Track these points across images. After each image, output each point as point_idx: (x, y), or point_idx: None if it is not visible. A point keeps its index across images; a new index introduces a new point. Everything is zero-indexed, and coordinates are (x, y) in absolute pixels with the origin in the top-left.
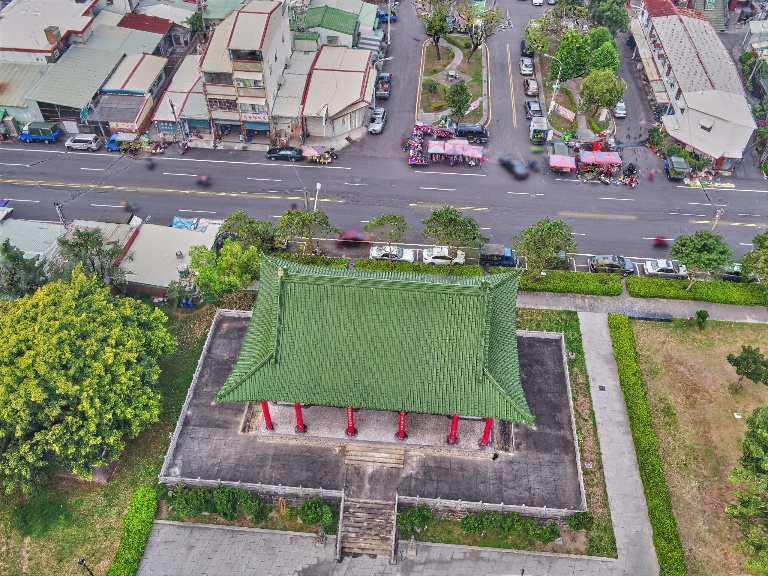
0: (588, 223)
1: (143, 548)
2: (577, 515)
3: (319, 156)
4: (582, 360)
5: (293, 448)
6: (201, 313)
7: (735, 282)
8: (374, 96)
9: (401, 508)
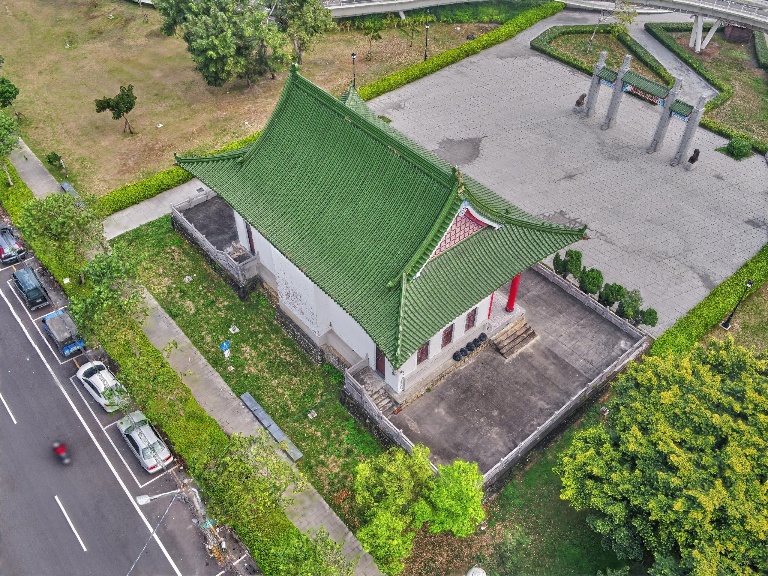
0: None
1: None
2: None
3: None
4: None
5: None
6: None
7: None
8: None
9: None
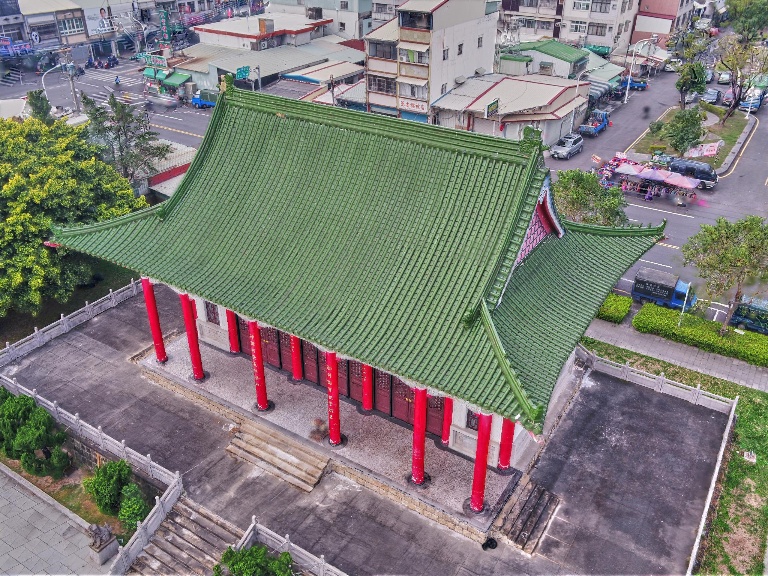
0: None
1: None
2: None
3: None
4: None
5: (174, 401)
6: None
7: None
8: (572, 120)
9: None
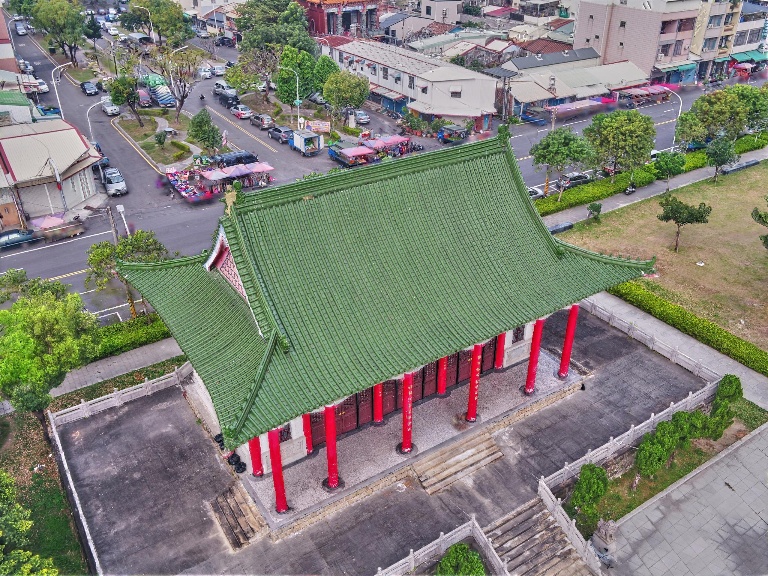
0: None
1: None
2: (728, 379)
3: None
4: None
5: (338, 521)
6: (6, 453)
7: (585, 184)
8: None
9: None
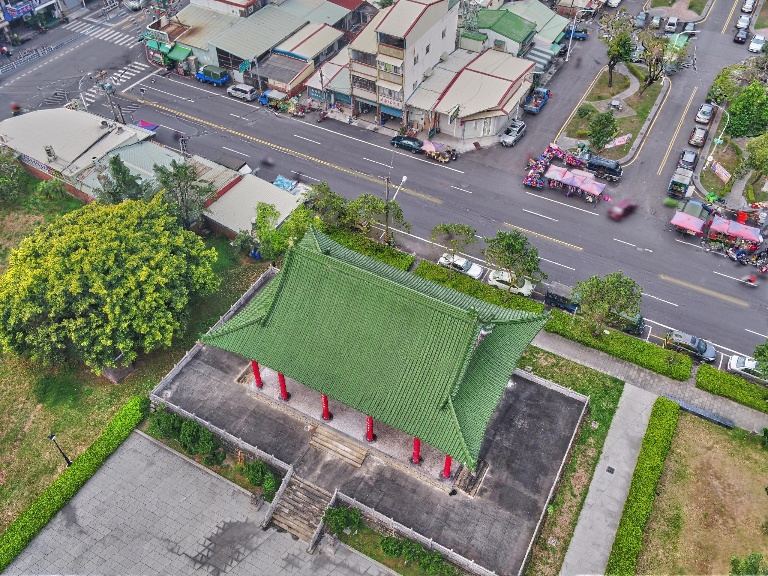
0: (688, 295)
1: (114, 448)
2: None
3: (438, 153)
4: (604, 433)
5: (272, 411)
6: (263, 266)
7: None
8: (518, 108)
9: (340, 504)
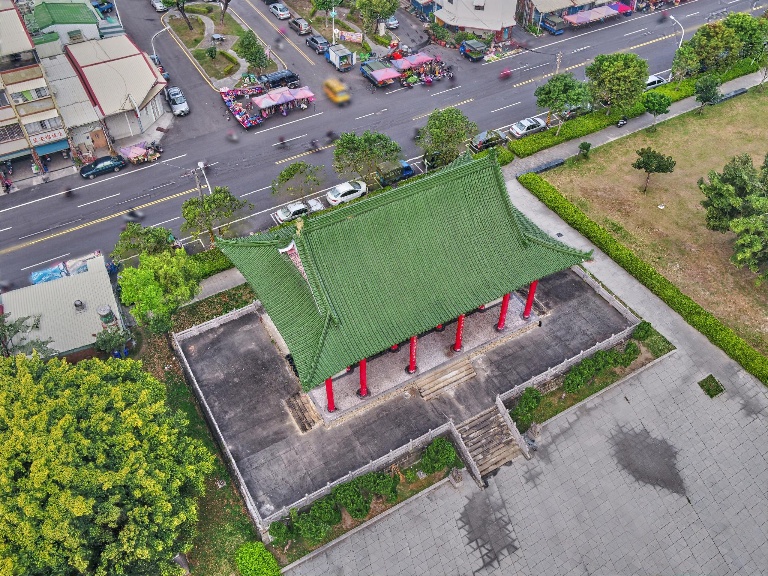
0: None
1: None
2: (641, 326)
3: (144, 154)
4: None
5: (367, 416)
6: (144, 355)
7: (583, 115)
8: None
9: None
